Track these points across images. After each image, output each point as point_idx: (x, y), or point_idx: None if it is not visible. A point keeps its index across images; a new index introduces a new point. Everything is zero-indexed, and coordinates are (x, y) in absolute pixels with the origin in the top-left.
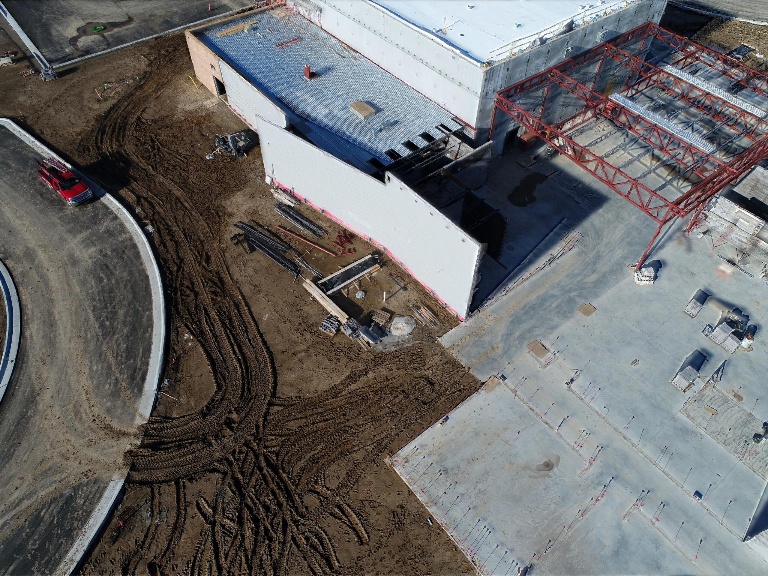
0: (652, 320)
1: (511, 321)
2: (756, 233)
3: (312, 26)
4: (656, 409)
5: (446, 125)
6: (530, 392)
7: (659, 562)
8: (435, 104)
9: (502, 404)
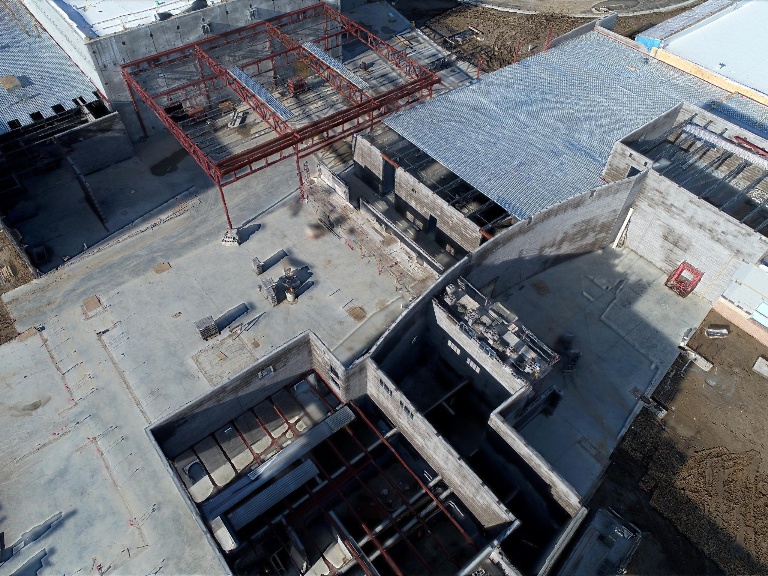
0: (218, 277)
1: (82, 278)
2: (346, 197)
3: (19, 7)
4: (170, 355)
5: (84, 98)
6: (60, 341)
7: (86, 488)
8: (87, 78)
9: (26, 352)
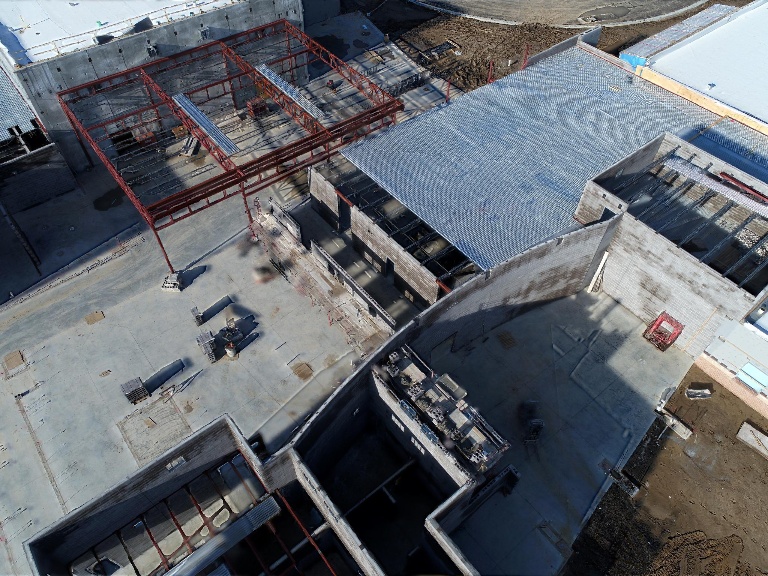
0: (154, 328)
1: (7, 330)
2: (298, 237)
3: None
4: (94, 422)
5: (20, 127)
6: None
7: None
8: None
9: None
